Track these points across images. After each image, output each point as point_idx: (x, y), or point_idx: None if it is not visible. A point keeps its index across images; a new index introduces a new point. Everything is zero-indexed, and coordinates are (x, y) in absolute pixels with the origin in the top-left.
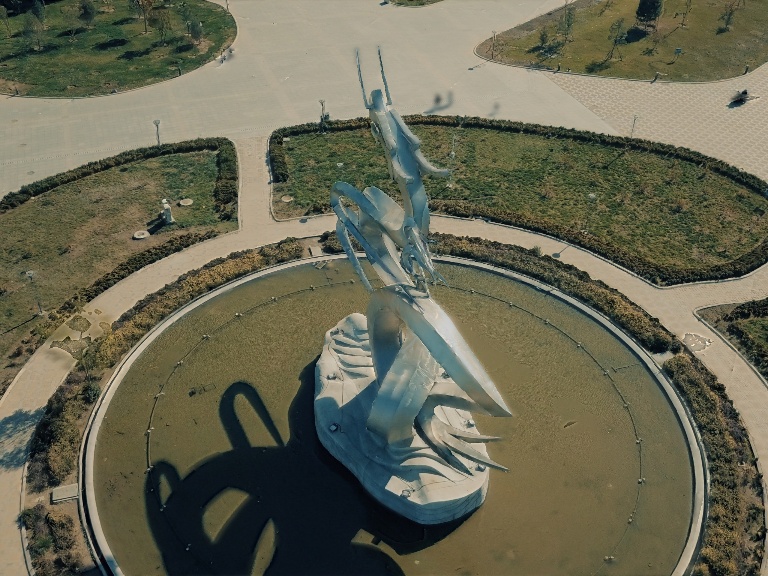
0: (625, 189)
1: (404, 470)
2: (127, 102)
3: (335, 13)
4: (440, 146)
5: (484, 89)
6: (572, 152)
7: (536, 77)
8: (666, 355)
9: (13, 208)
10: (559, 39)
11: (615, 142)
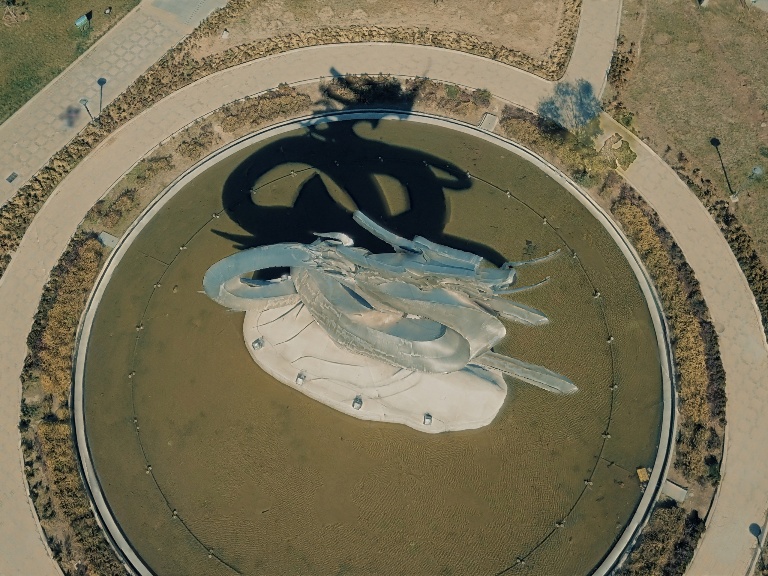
0: None
1: None
2: None
3: None
4: None
5: None
6: None
7: None
8: None
9: None
10: None
11: None
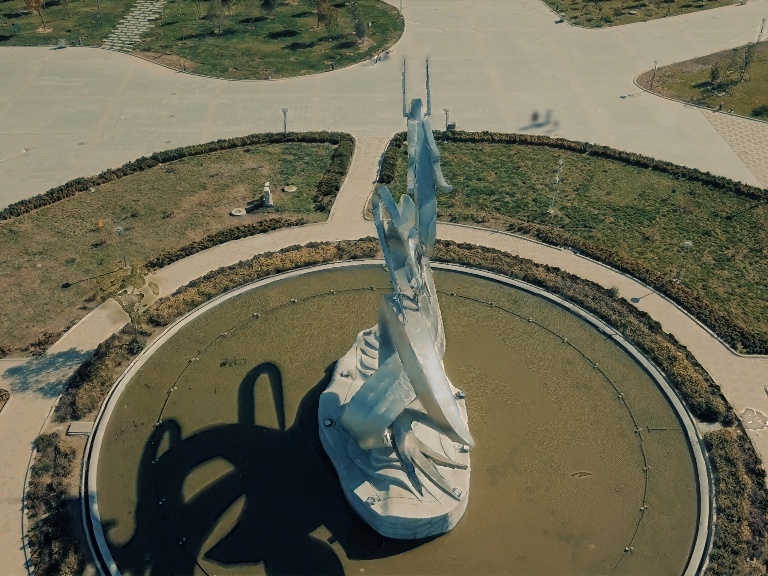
0: (742, 244)
1: (378, 478)
2: (275, 89)
3: (505, 26)
4: (557, 170)
5: (628, 119)
6: (698, 196)
7: (691, 114)
8: (713, 426)
9: (141, 171)
10: (734, 77)
11: (751, 193)
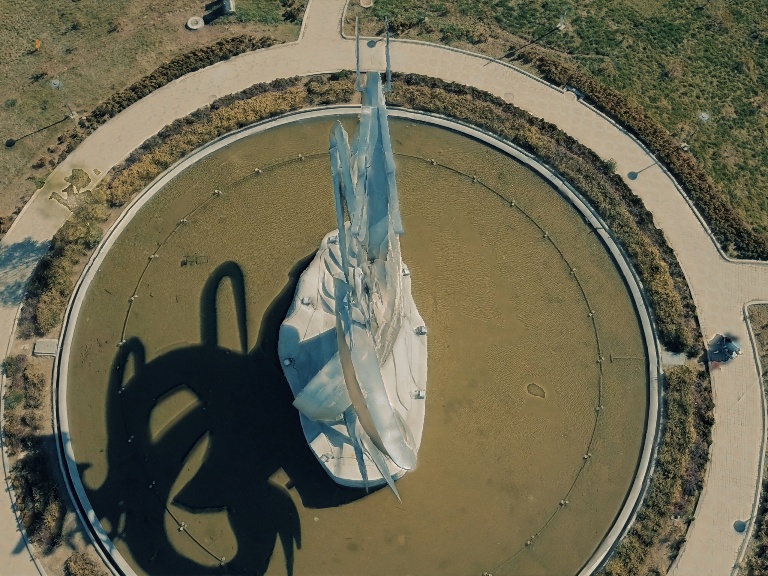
0: None
1: (334, 431)
2: None
3: None
4: None
5: None
6: (742, 3)
7: None
8: (677, 357)
9: None
10: None
11: None
